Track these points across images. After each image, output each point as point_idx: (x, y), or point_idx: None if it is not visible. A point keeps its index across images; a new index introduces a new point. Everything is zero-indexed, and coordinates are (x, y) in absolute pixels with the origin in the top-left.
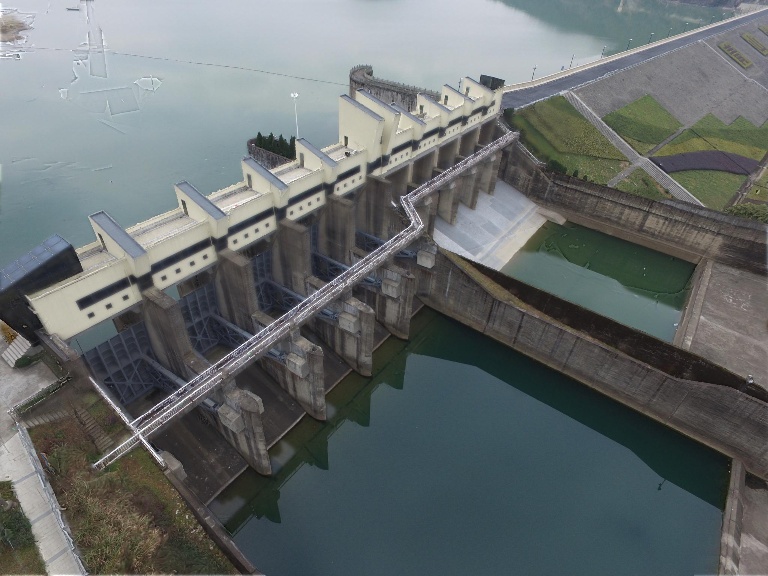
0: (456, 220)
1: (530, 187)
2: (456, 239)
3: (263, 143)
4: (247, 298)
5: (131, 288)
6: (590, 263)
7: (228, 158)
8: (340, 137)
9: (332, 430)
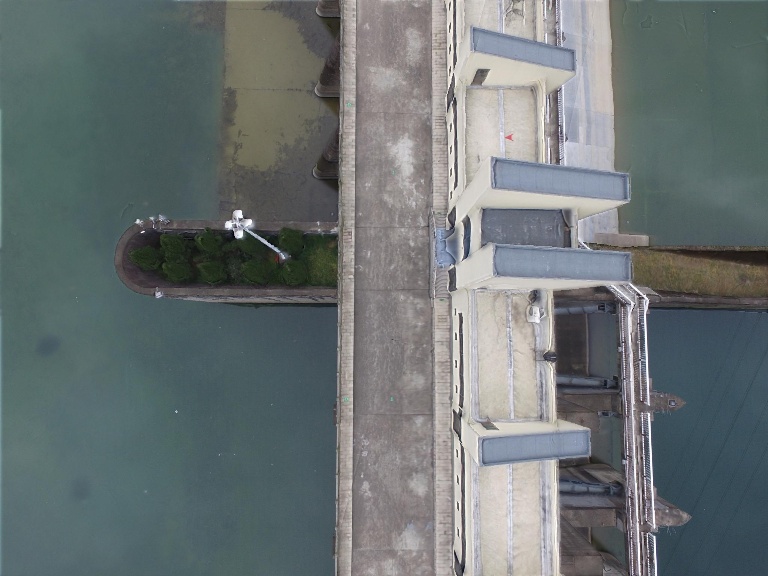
0: None
1: None
2: None
3: (172, 274)
4: None
5: None
6: None
7: None
8: (467, 287)
9: (622, 557)
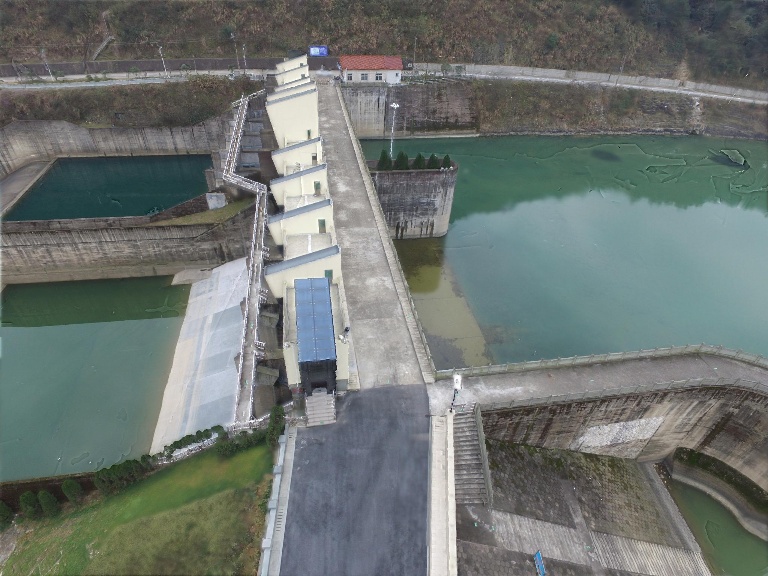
0: None
1: None
2: None
3: None
4: None
5: None
6: None
7: (590, 256)
8: None
9: None
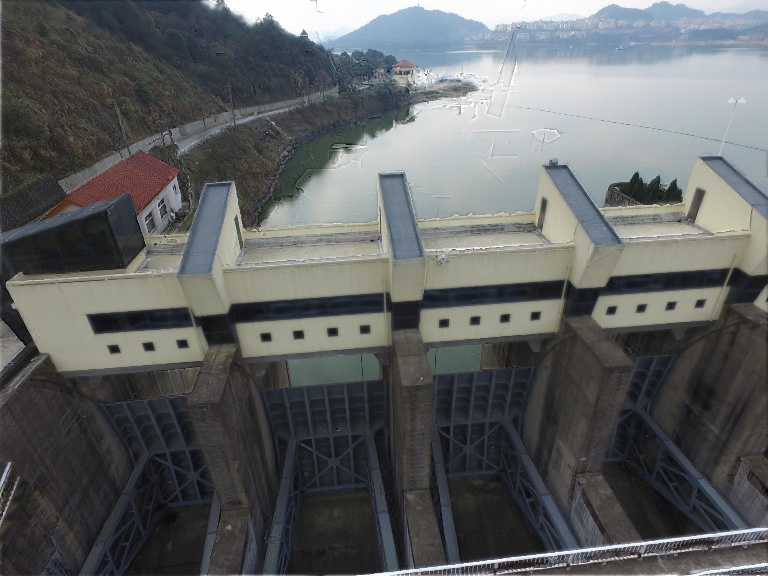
0: None
1: None
2: None
3: (635, 189)
4: (403, 455)
5: (195, 331)
6: None
7: None
8: None
9: None
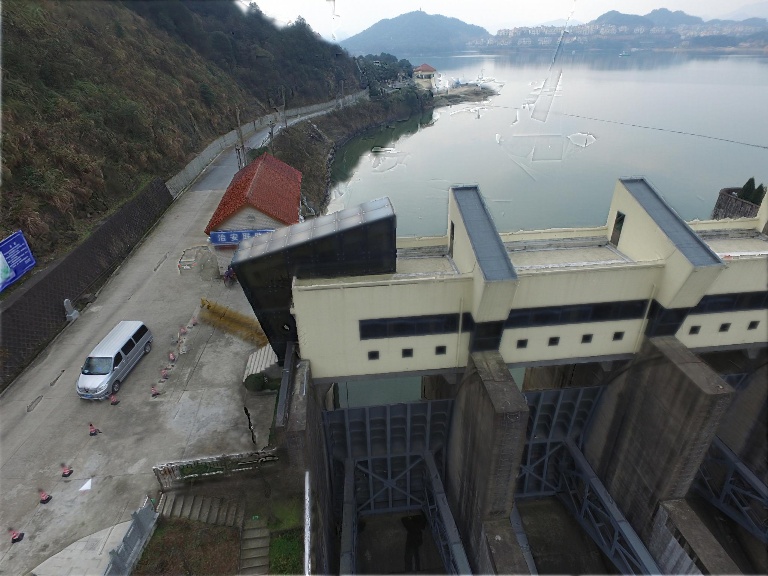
0: None
1: None
2: None
3: (755, 194)
4: (675, 464)
5: (457, 337)
6: None
7: None
8: None
9: None
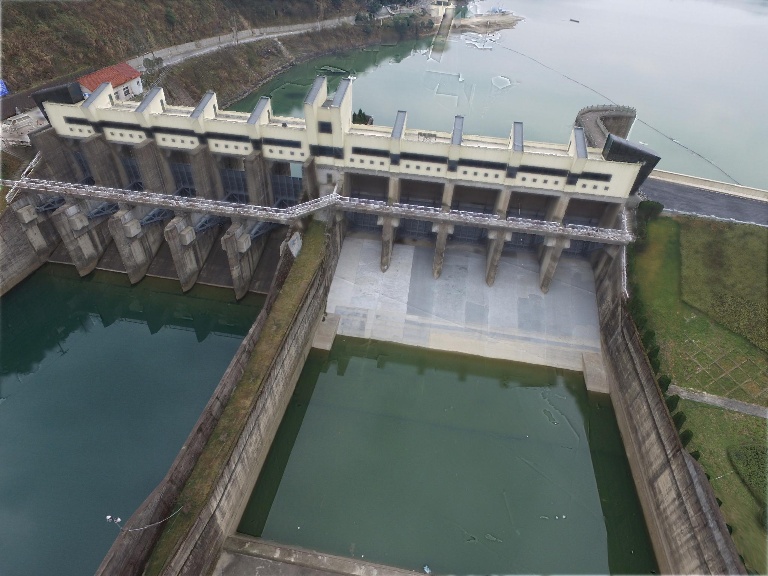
0: (448, 277)
1: (606, 319)
2: (415, 288)
3: None
4: (141, 174)
5: None
6: (603, 479)
7: None
8: None
9: (128, 292)
